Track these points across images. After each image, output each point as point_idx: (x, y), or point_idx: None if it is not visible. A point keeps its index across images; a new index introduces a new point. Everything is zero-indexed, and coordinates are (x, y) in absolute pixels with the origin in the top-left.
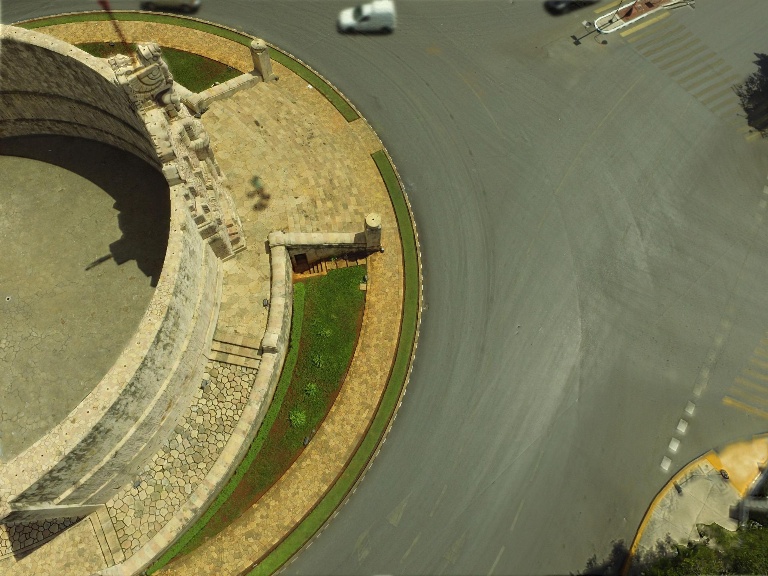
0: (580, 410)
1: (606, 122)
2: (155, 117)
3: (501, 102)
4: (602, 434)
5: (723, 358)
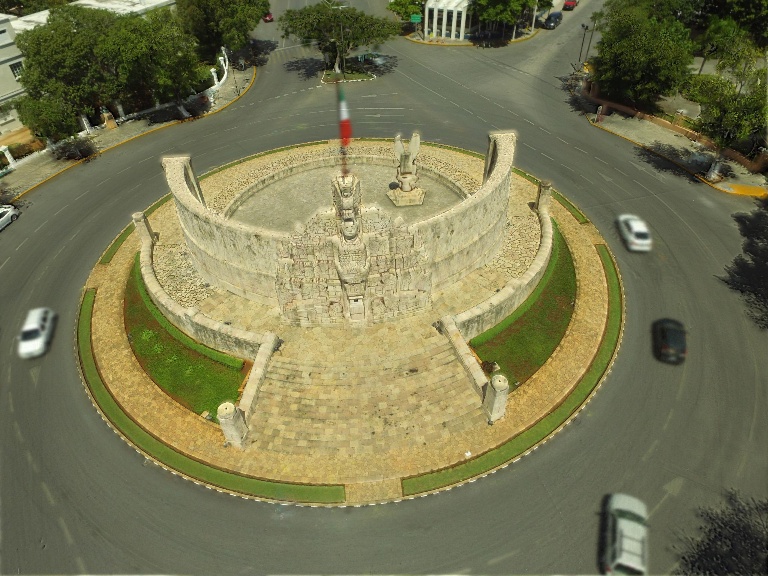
0: None
1: None
2: (329, 215)
3: None
4: None
5: None
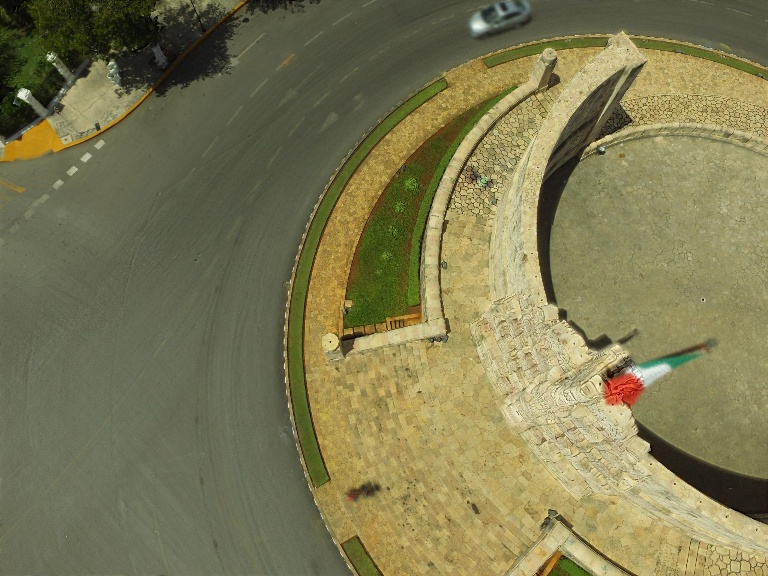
0: (160, 186)
1: (3, 531)
2: (577, 354)
3: (140, 571)
4: (147, 167)
5: (5, 224)
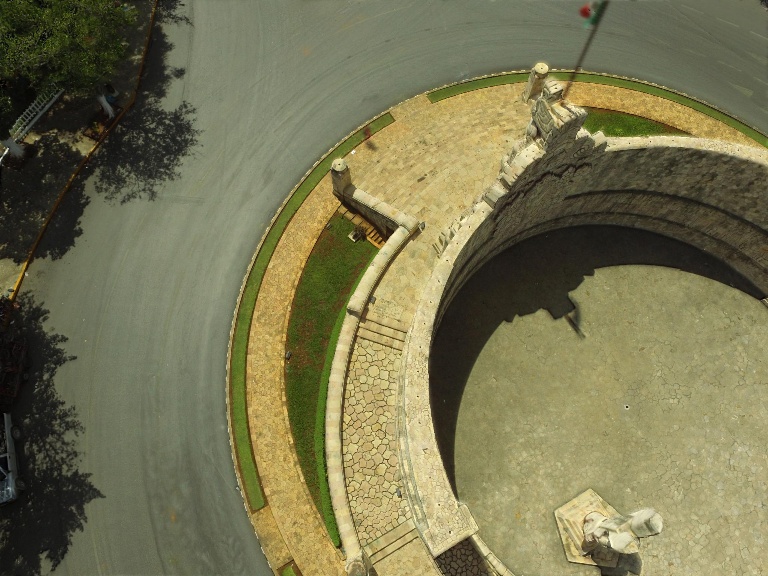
0: None
1: None
2: None
3: (371, 4)
4: None
5: None
